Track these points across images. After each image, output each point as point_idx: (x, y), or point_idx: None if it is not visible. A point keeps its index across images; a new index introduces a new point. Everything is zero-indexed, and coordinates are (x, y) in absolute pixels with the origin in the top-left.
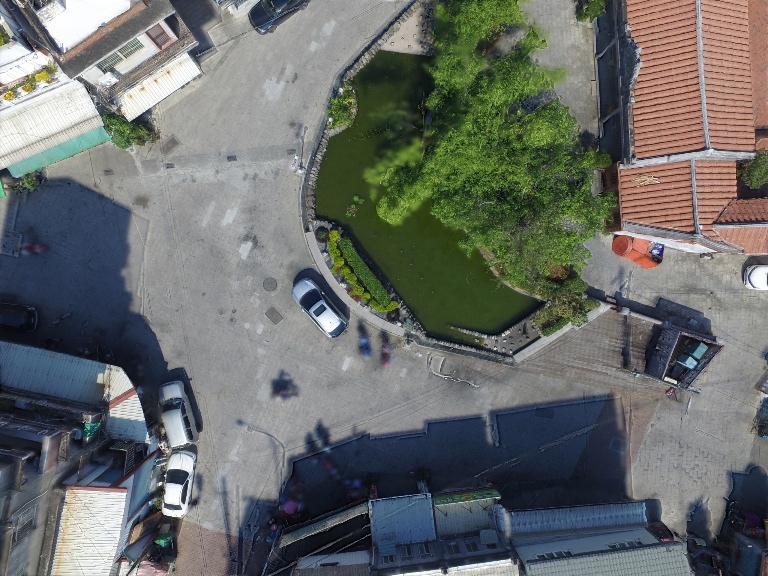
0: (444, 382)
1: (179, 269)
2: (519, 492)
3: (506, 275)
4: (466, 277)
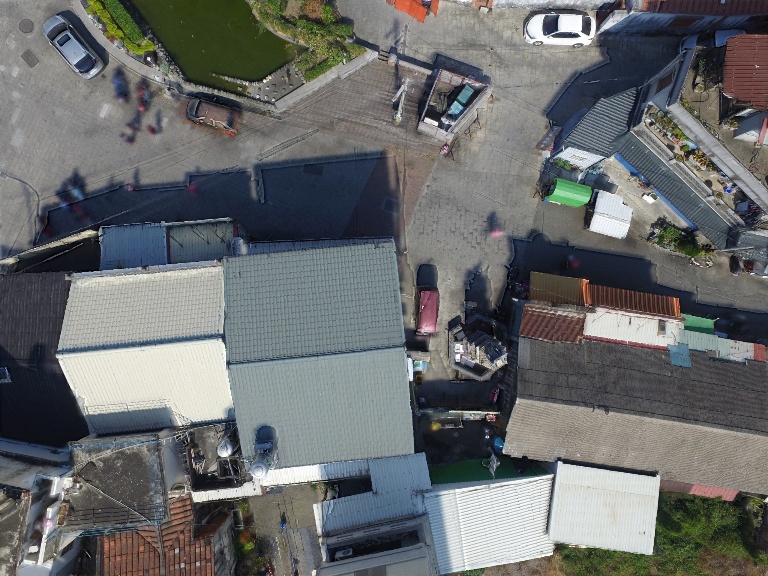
0: (207, 133)
1: None
2: None
3: (263, 13)
4: (228, 21)
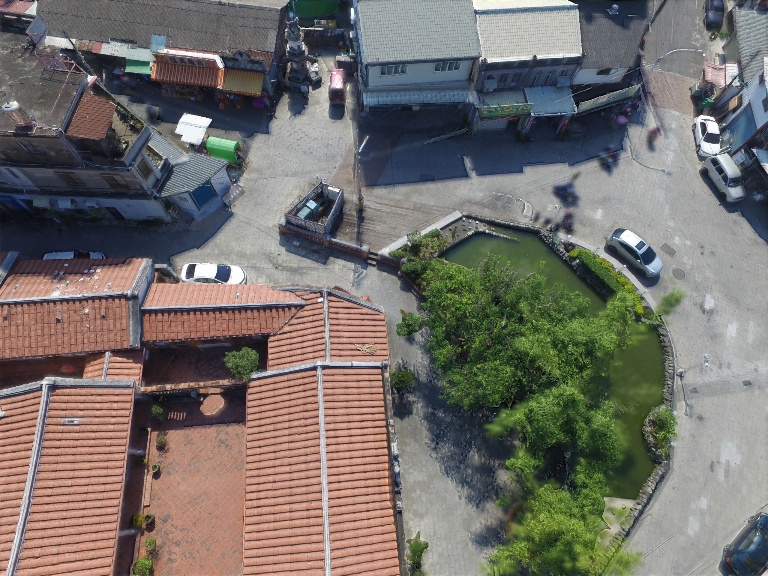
0: None
1: (759, 286)
2: (445, 126)
3: None
4: None
